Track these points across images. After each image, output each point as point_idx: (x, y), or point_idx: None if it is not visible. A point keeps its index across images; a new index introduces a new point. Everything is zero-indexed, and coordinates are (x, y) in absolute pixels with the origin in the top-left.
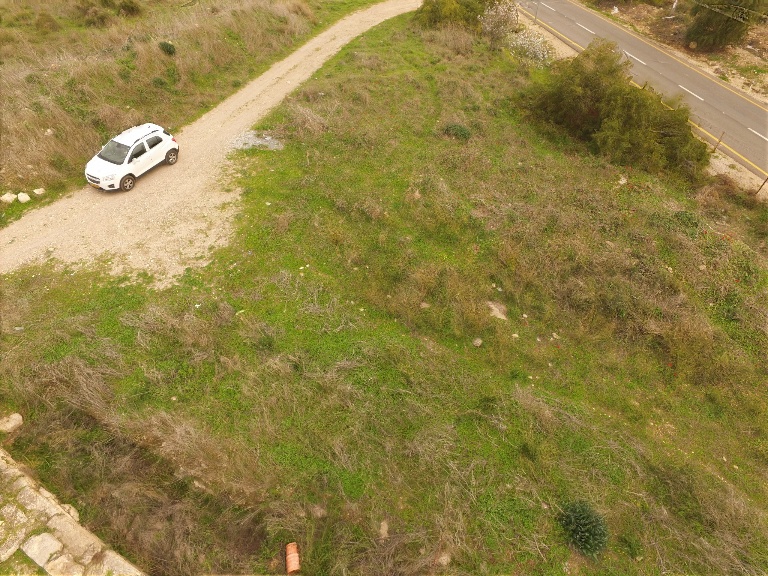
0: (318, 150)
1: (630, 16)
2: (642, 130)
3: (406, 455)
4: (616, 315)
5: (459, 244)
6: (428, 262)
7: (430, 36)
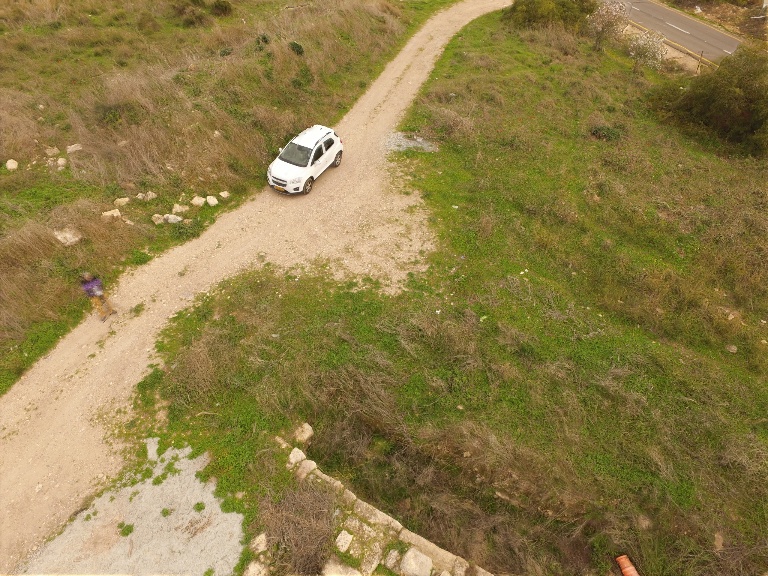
0: (477, 152)
1: (715, 16)
2: None
3: (726, 466)
4: None
5: (663, 248)
6: (641, 266)
7: (530, 36)
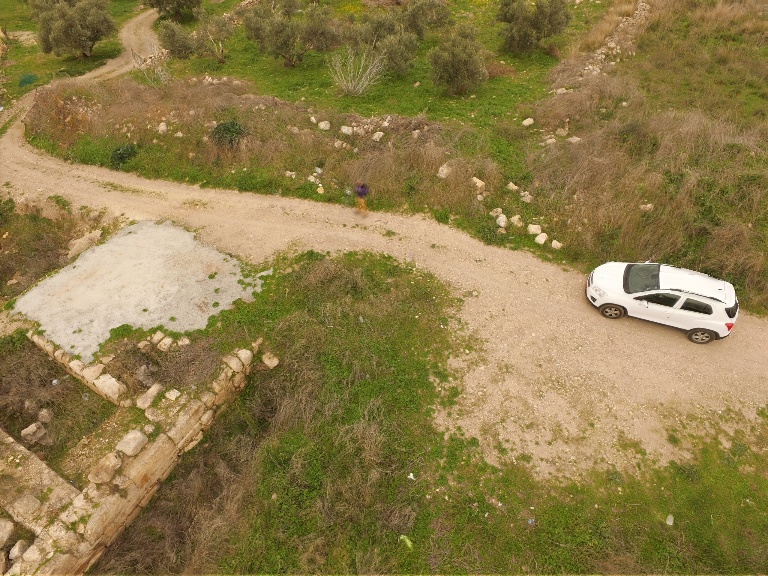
0: None
1: None
2: None
3: None
4: None
5: None
6: None
7: None
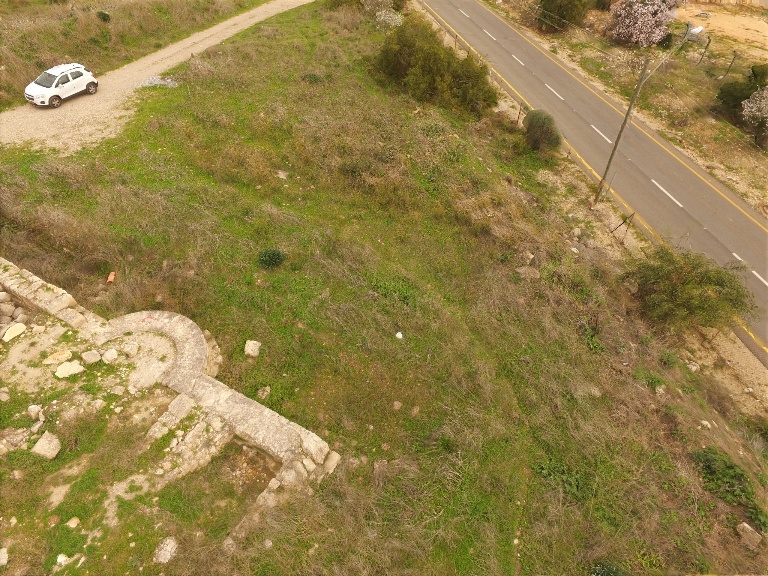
0: (202, 87)
1: (510, 5)
2: (445, 79)
3: None
4: (351, 174)
5: (275, 141)
6: None
7: (329, 16)
